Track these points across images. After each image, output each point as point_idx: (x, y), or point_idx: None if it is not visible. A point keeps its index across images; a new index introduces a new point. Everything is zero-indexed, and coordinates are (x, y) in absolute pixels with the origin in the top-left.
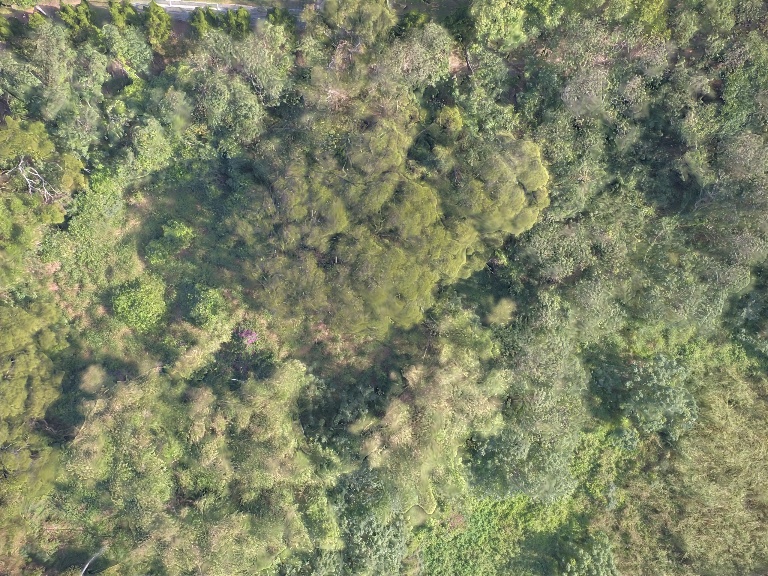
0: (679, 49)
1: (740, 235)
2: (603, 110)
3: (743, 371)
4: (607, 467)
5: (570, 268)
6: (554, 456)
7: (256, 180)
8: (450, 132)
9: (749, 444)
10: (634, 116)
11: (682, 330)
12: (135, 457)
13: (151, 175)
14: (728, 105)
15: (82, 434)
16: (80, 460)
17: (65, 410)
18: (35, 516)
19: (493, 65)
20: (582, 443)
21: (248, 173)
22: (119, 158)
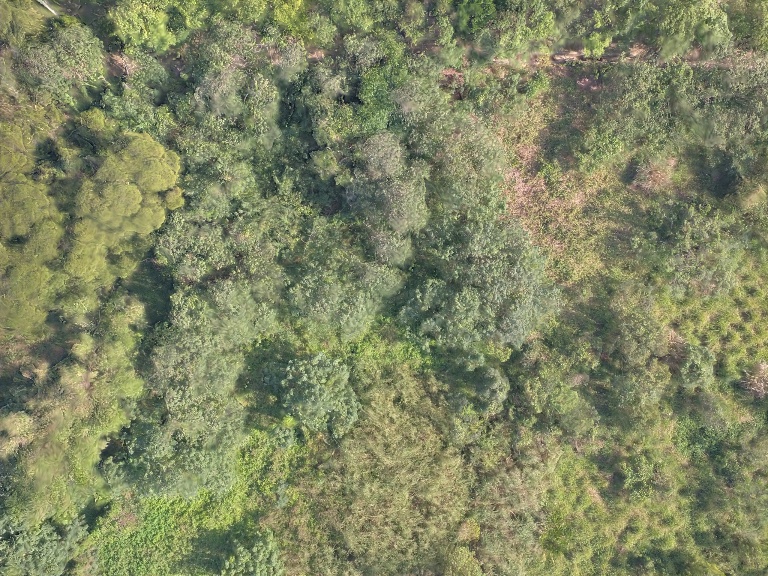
0: (323, 48)
1: (378, 233)
2: (247, 109)
3: (416, 368)
4: (279, 465)
5: (203, 267)
6: (197, 454)
7: None
8: (96, 132)
9: (411, 441)
10: (292, 115)
11: None
12: None
13: None
14: (363, 104)
15: None
16: None
17: None
18: None
19: (147, 65)
20: (257, 441)
21: None
22: None
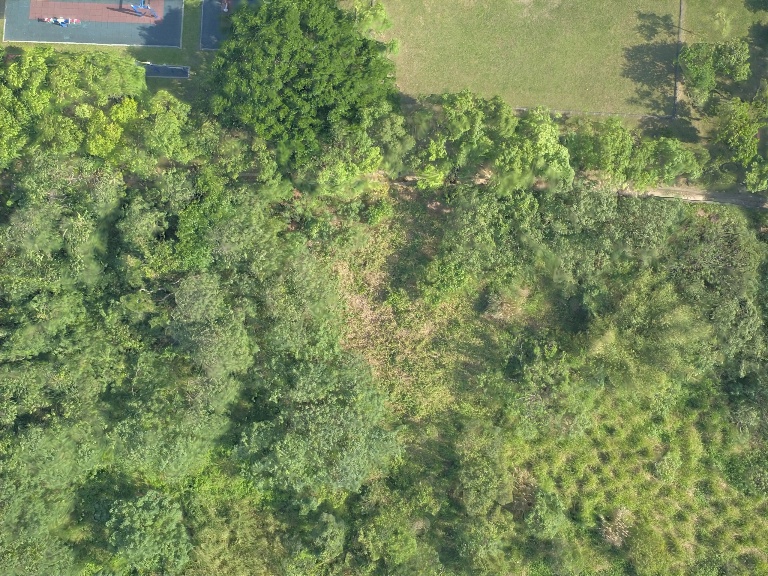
0: (147, 181)
1: None
2: (68, 244)
3: (256, 504)
4: None
5: (13, 412)
6: None
7: None
8: None
9: None
10: (123, 245)
11: None
12: None
13: None
14: (181, 243)
15: None
16: None
17: None
18: None
19: None
20: None
21: None
22: None
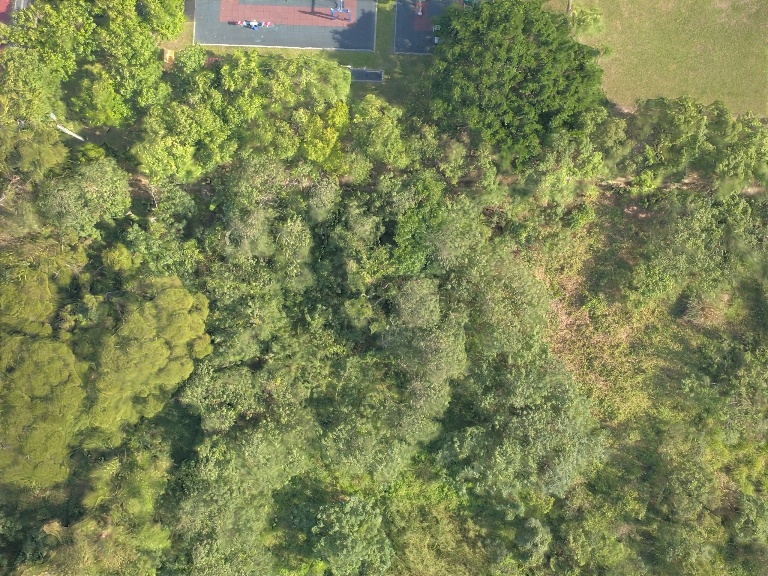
0: (359, 185)
1: (415, 382)
2: (279, 249)
3: (452, 509)
4: None
5: (232, 418)
6: None
7: None
8: (123, 271)
9: None
10: (326, 249)
11: None
12: None
13: None
14: (400, 248)
15: None
16: None
17: None
18: None
19: (176, 198)
20: None
21: None
22: None
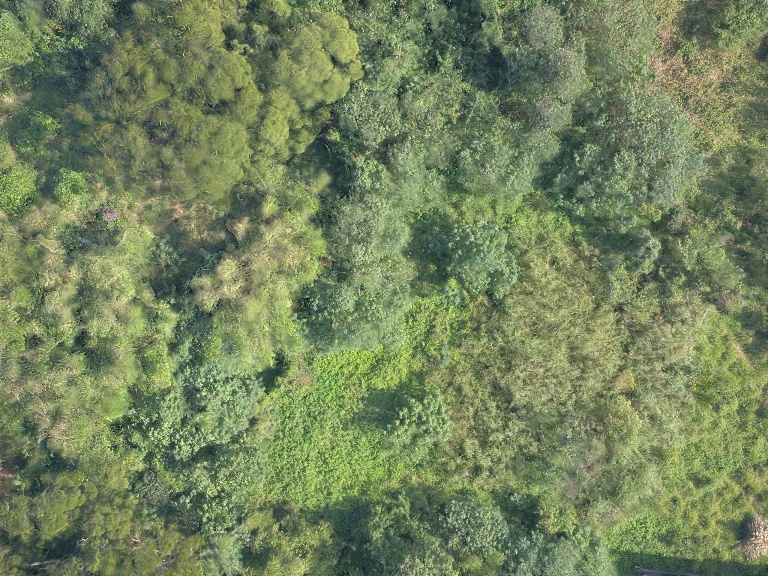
0: None
1: (542, 100)
2: None
3: (566, 237)
4: (442, 328)
5: (383, 132)
6: (377, 307)
7: None
8: (278, 17)
9: (567, 300)
10: (452, 0)
11: (509, 201)
12: None
13: (21, 72)
14: None
15: None
16: None
17: None
18: None
19: None
20: (419, 307)
21: None
22: None
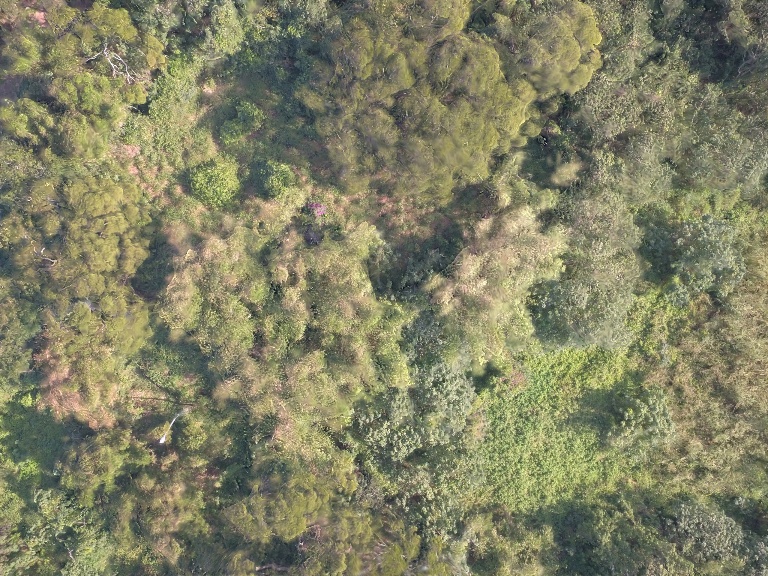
0: None
1: None
2: None
3: None
4: (659, 326)
5: (623, 124)
6: (611, 305)
7: (323, 61)
8: (506, 5)
9: None
10: None
11: (727, 196)
12: (223, 304)
13: (223, 62)
14: None
15: (174, 282)
16: (172, 307)
17: (151, 277)
18: (121, 384)
19: None
20: (634, 305)
21: (315, 55)
22: (194, 47)
